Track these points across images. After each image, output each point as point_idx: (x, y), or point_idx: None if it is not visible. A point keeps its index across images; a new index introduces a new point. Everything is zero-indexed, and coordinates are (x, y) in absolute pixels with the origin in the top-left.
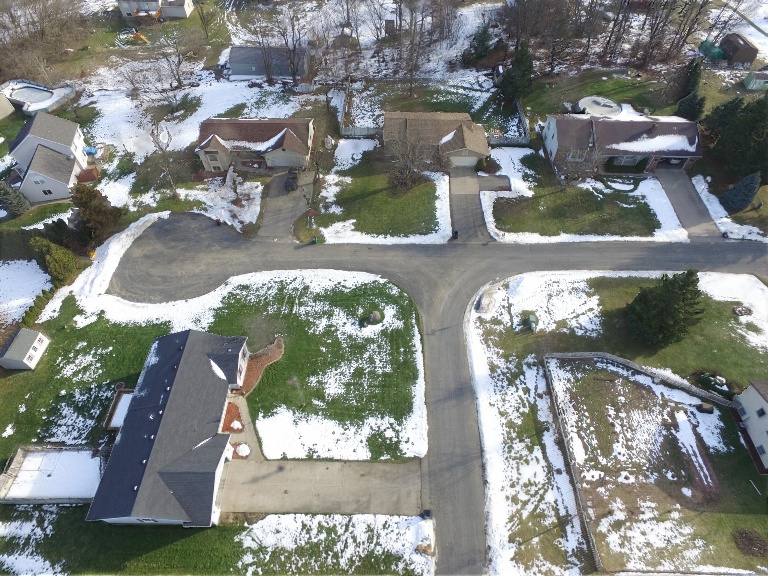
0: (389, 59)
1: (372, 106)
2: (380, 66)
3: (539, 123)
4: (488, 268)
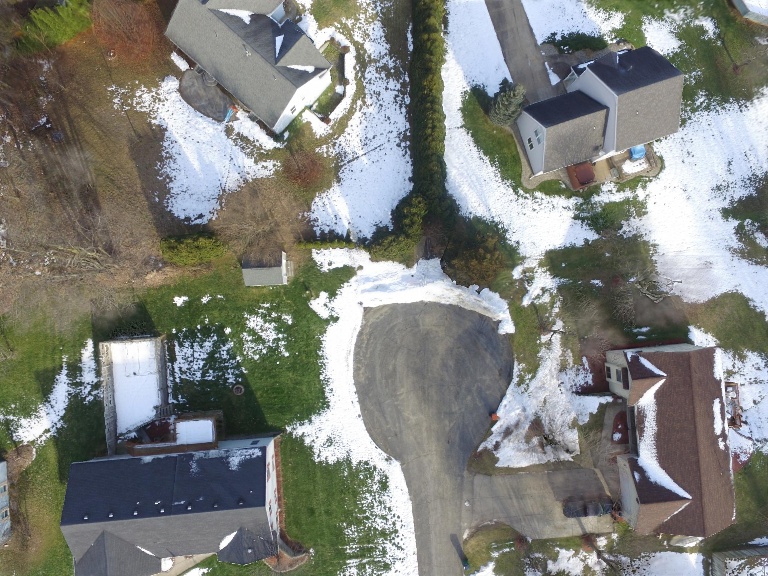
0: None
1: None
2: None
3: None
4: None
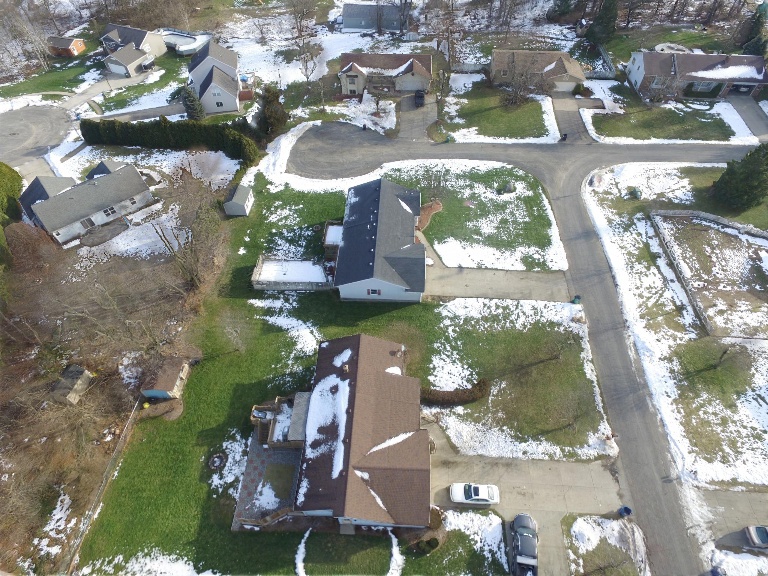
0: (480, 17)
1: (473, 51)
2: (473, 22)
3: (621, 63)
4: (595, 159)
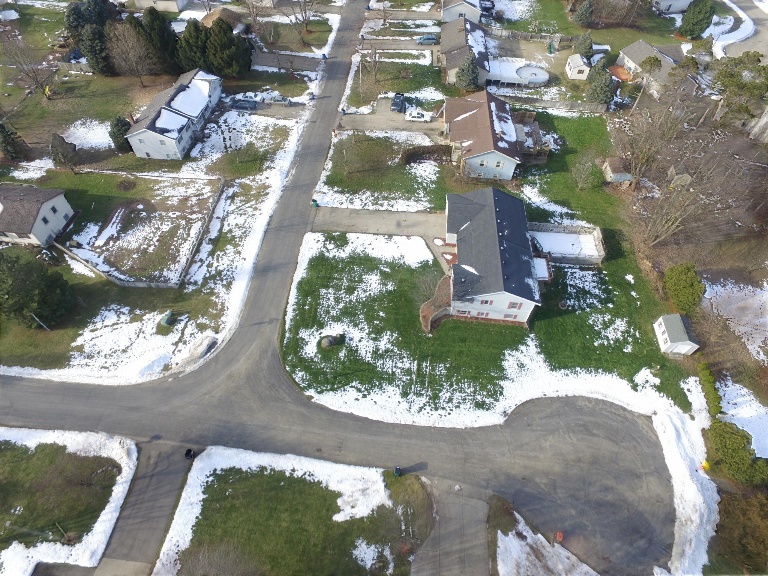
0: None
1: None
2: None
3: None
4: (174, 395)
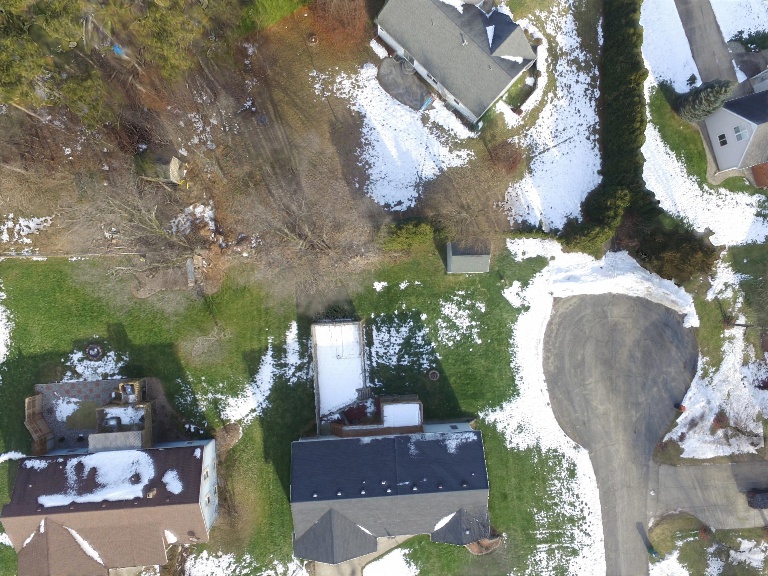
0: None
1: None
2: None
3: None
4: None
